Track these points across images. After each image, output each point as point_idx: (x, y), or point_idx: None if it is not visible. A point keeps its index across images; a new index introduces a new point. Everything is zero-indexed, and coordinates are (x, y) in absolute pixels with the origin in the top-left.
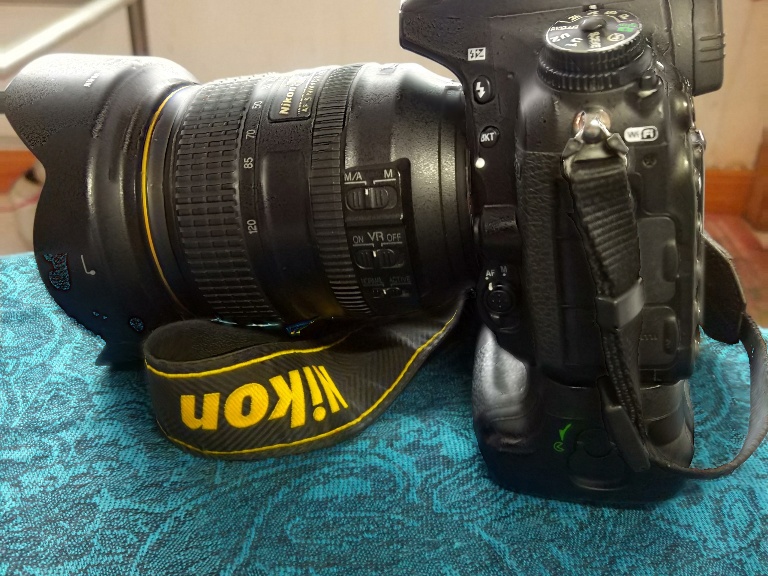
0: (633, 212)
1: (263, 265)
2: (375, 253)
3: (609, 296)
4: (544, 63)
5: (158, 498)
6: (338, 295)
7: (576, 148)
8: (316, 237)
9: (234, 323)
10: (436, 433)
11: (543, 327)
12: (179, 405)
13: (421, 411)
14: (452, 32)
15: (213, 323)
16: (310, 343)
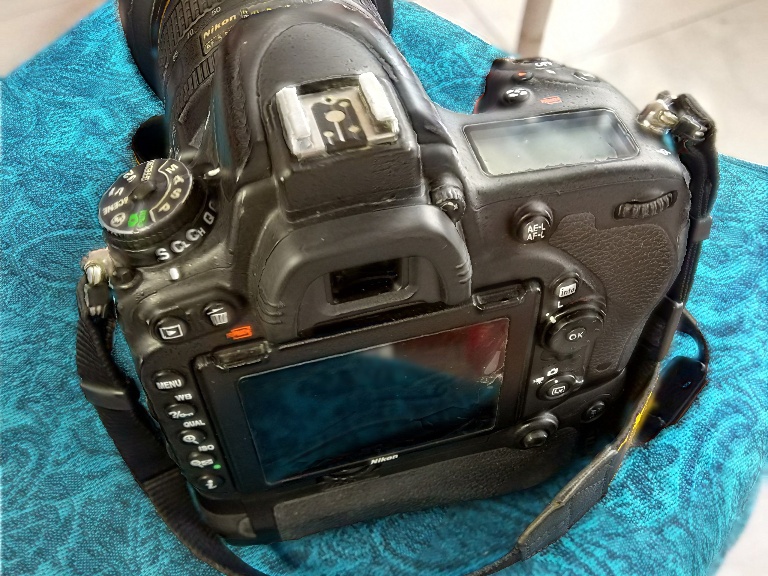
0: (98, 348)
1: None
2: None
3: None
4: None
5: None
6: None
7: None
8: None
9: None
10: None
11: None
12: None
13: None
14: None
15: None
16: None
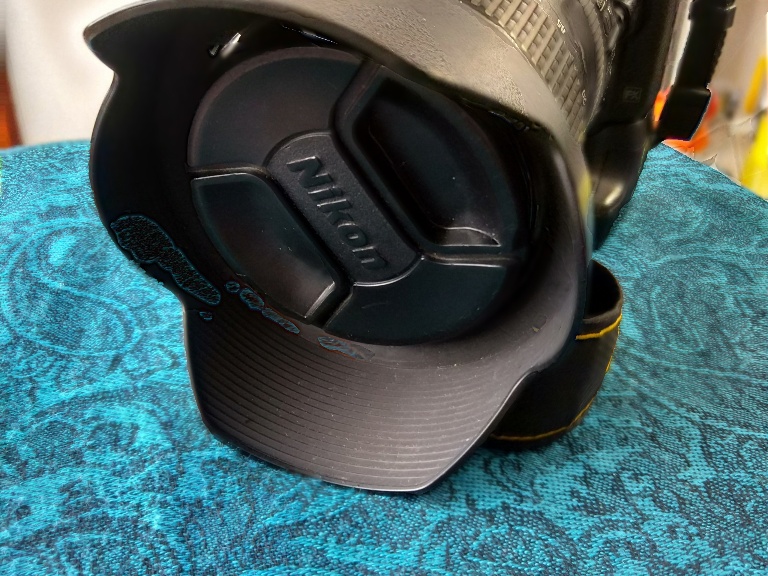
0: None
1: None
2: None
3: (730, 5)
4: None
5: (674, 434)
6: None
7: None
8: (596, 82)
9: None
10: None
11: (656, 73)
12: (612, 349)
13: None
14: None
15: None
16: None
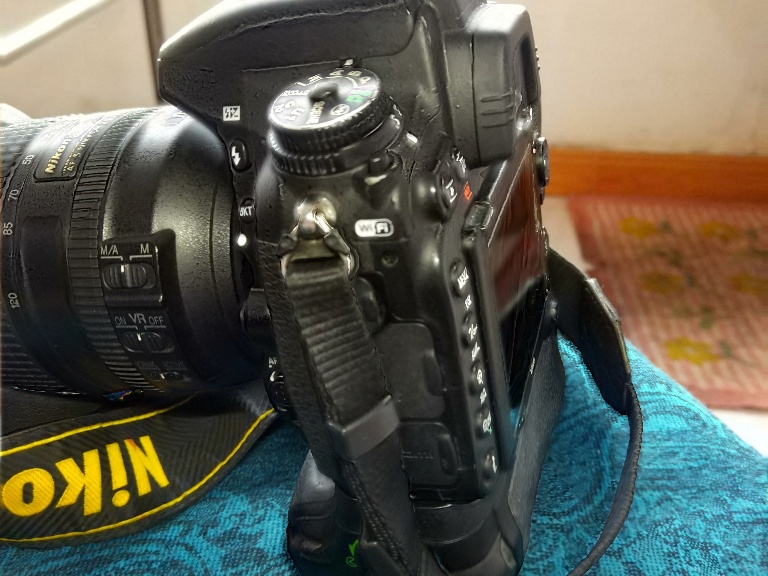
0: (364, 323)
1: (34, 341)
2: (140, 336)
3: (338, 422)
4: (272, 135)
5: None
6: (120, 375)
7: (289, 246)
8: (79, 315)
9: (42, 391)
10: (261, 518)
11: (311, 434)
12: None
13: (254, 489)
14: (206, 86)
15: (17, 391)
16: (136, 409)
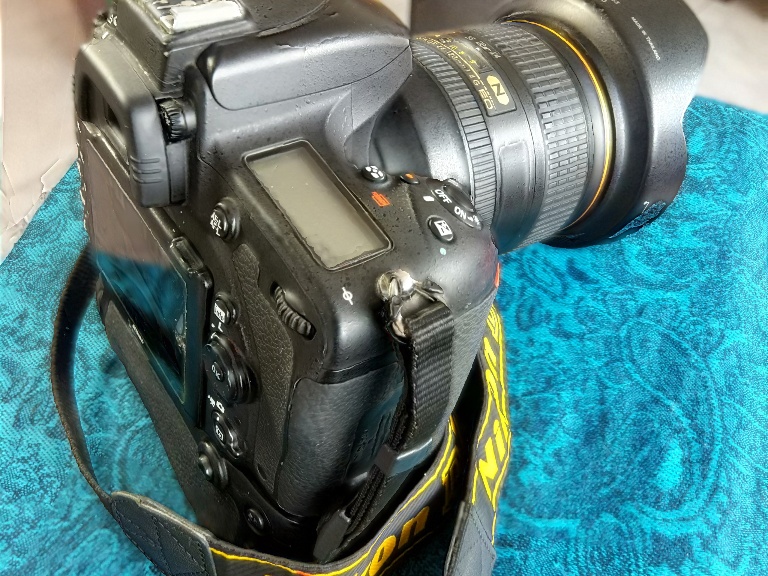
0: None
1: None
2: None
3: None
4: None
5: None
6: None
7: None
8: None
9: None
10: None
11: None
12: None
13: None
14: None
15: None
16: None
